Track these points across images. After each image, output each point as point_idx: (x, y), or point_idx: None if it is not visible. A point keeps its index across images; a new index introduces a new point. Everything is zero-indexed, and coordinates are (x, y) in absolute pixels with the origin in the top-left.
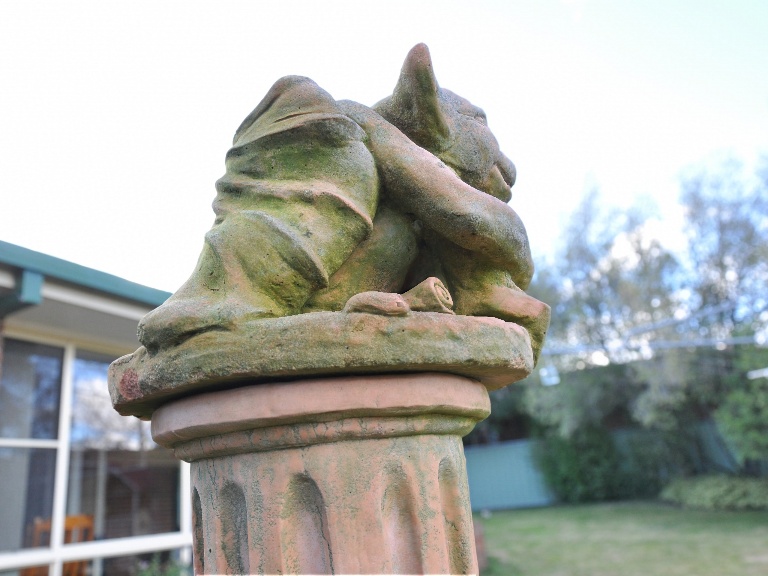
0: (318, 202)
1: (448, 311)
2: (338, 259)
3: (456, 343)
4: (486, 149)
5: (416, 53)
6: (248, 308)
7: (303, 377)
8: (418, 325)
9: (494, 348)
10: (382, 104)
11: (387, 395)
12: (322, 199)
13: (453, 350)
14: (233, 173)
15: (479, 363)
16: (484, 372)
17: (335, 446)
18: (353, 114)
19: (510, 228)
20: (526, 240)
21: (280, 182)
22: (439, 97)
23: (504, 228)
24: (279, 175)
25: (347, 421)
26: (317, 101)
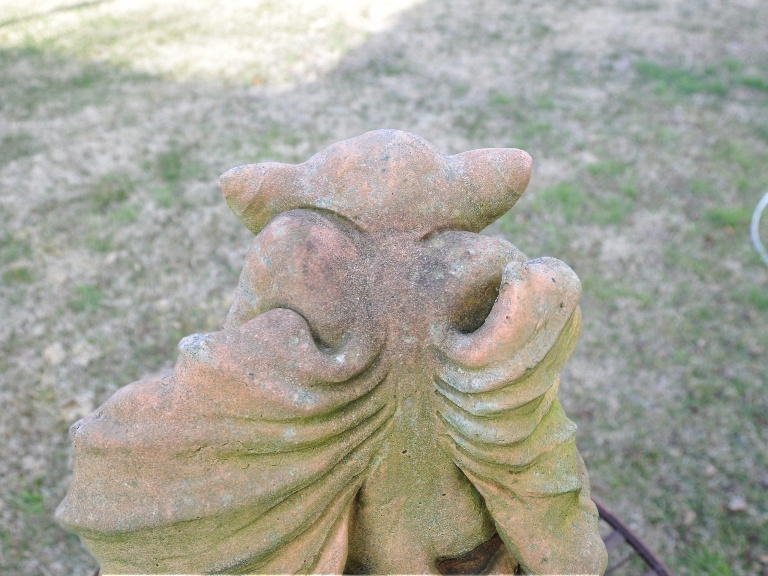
0: None
1: None
2: None
3: None
4: None
5: None
6: None
7: None
8: None
9: None
10: (465, 210)
11: None
12: None
13: None
14: None
15: None
16: None
17: None
18: None
19: None
20: None
21: None
22: None
23: None
24: None
25: None
26: None
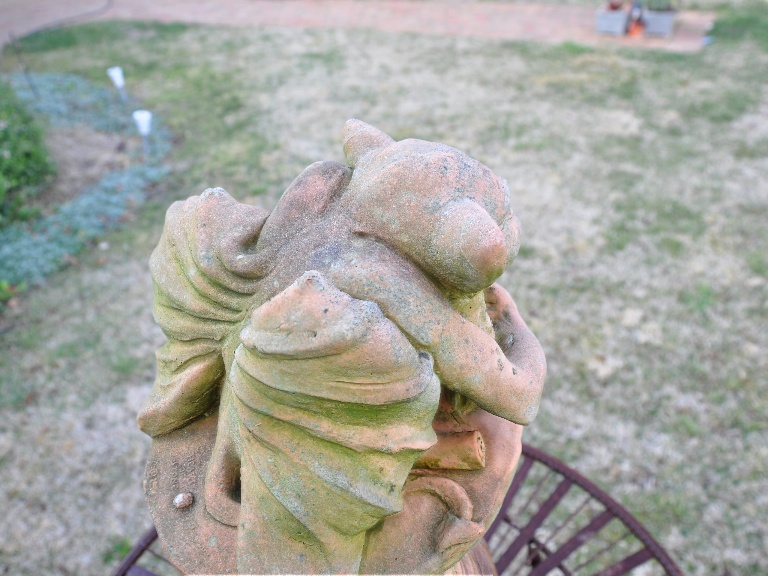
0: (396, 454)
1: None
2: None
3: None
4: None
5: (495, 255)
6: (355, 570)
7: None
8: None
9: None
10: (416, 242)
11: None
12: (401, 452)
13: None
14: (269, 400)
15: None
16: None
17: None
18: (416, 333)
19: None
20: None
21: (346, 430)
22: None
23: None
24: (342, 421)
25: None
26: (395, 369)
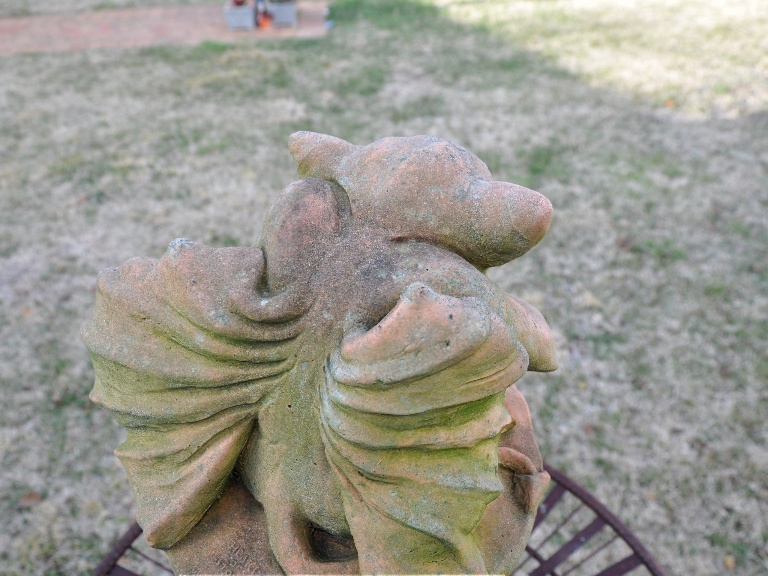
0: None
1: None
2: None
3: None
4: None
5: None
6: None
7: None
8: None
9: None
10: (459, 232)
11: None
12: None
13: None
14: (392, 432)
15: None
16: None
17: None
18: None
19: None
20: None
21: (460, 431)
22: None
23: None
24: None
25: None
26: None
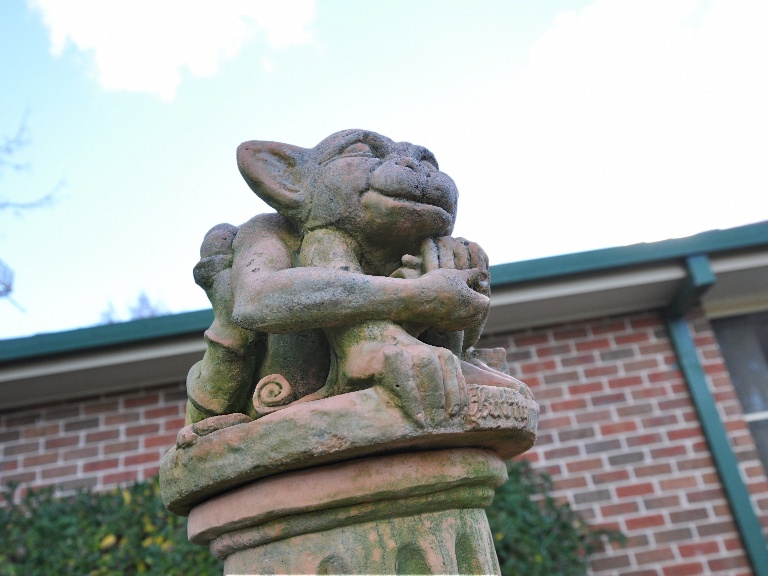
0: None
1: (268, 411)
2: (228, 384)
3: (237, 455)
4: (338, 189)
5: None
6: None
7: (195, 503)
8: (201, 450)
9: (281, 445)
10: None
11: (222, 513)
12: None
13: (234, 463)
14: None
15: (269, 466)
16: (336, 457)
17: (235, 556)
18: None
19: (289, 300)
20: (352, 285)
21: None
22: (298, 164)
23: (278, 307)
24: None
25: (224, 536)
26: None
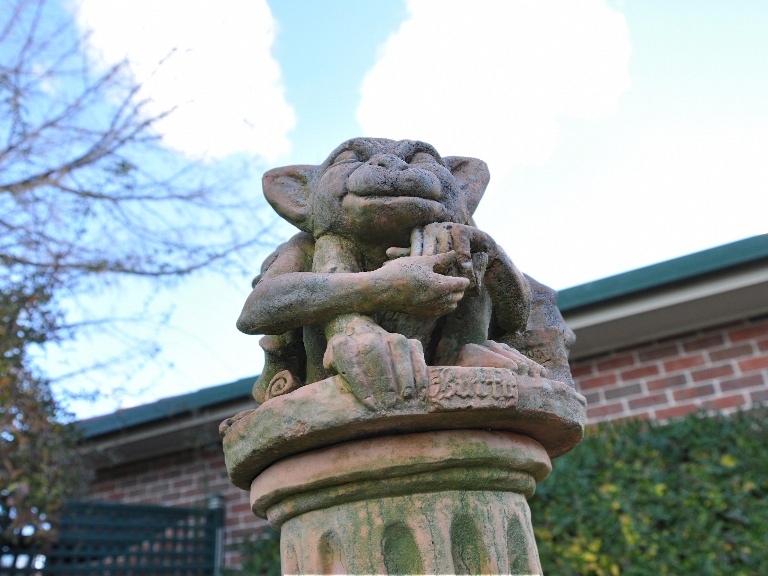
0: None
1: None
2: None
3: None
4: None
5: None
6: None
7: None
8: None
9: (265, 431)
10: None
11: None
12: None
13: None
14: None
15: (261, 450)
16: (318, 441)
17: None
18: None
19: (267, 305)
20: (314, 285)
21: None
22: None
23: (260, 312)
24: None
25: None
26: None
